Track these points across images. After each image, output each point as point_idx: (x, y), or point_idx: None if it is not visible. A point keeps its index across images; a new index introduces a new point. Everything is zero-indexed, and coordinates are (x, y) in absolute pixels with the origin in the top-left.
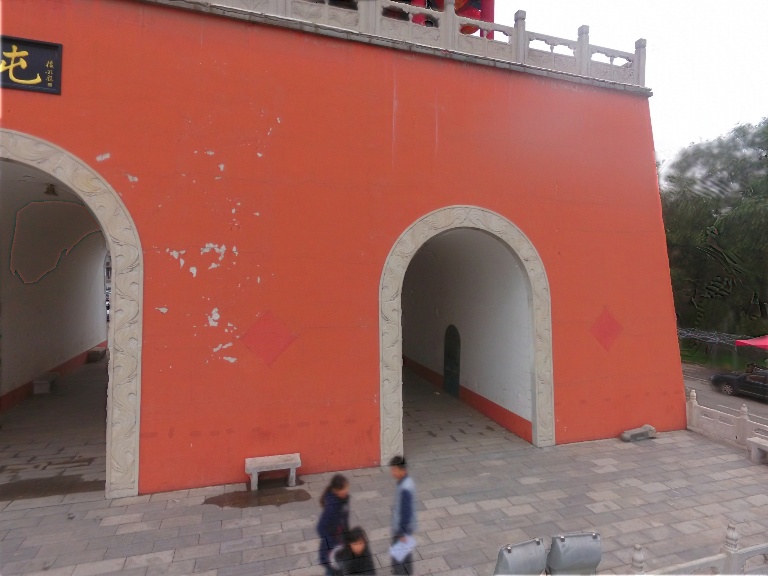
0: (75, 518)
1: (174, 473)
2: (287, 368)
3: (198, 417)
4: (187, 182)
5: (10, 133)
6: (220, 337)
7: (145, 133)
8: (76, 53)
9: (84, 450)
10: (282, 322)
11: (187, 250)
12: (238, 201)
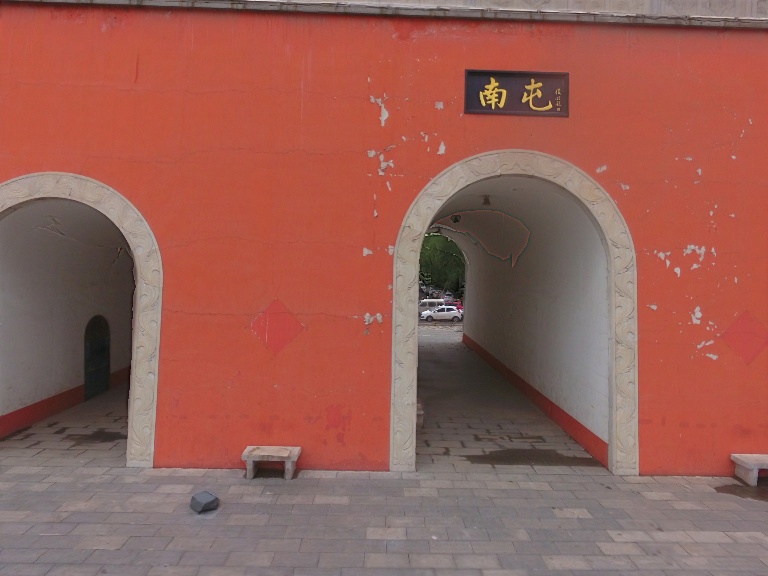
0: (613, 488)
1: (667, 459)
2: (765, 368)
3: (686, 409)
4: (670, 188)
5: (534, 154)
6: (703, 335)
7: (633, 145)
8: (577, 79)
9: (520, 428)
10: (759, 322)
11: (672, 252)
12: (715, 204)
